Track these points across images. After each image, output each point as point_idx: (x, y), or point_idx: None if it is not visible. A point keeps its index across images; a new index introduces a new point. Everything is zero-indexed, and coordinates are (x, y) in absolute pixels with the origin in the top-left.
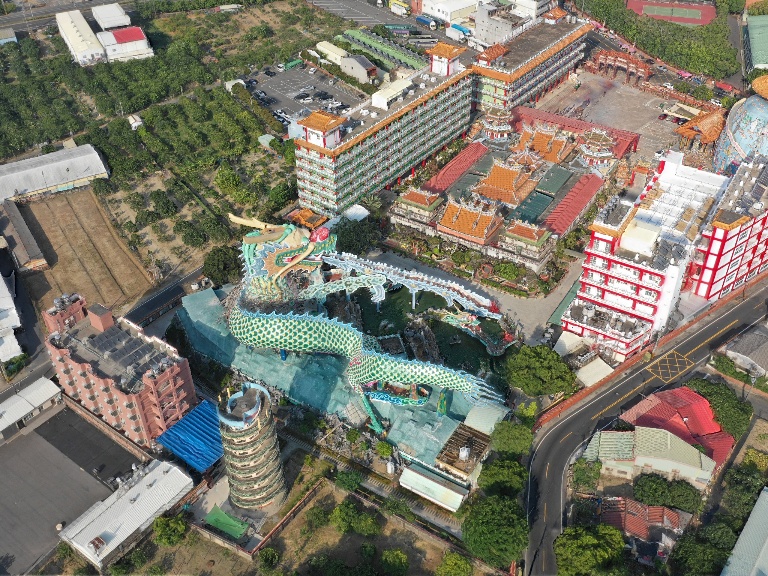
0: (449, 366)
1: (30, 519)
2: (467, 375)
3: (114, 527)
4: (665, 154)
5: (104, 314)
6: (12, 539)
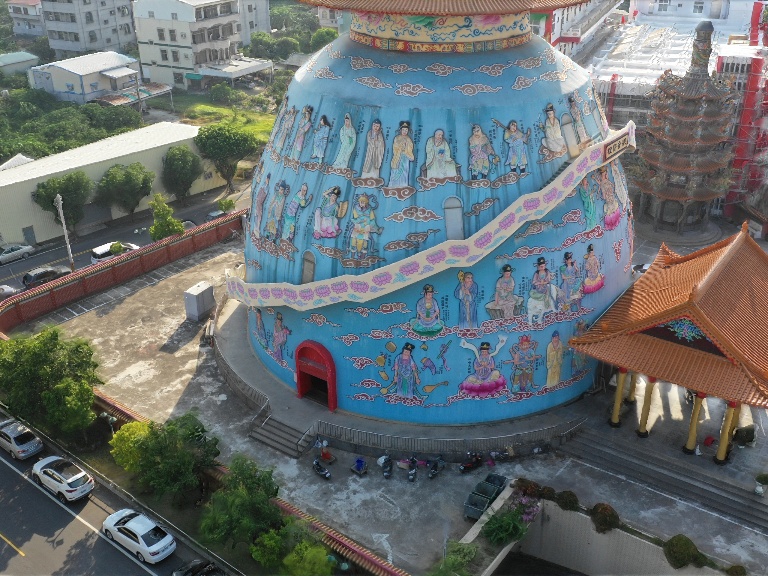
0: None
1: None
2: None
3: None
4: (766, 51)
5: None
6: None
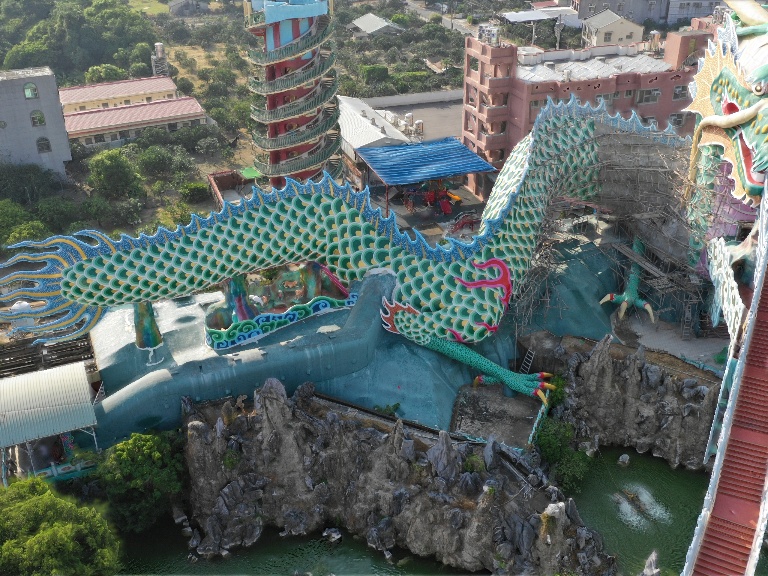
0: (356, 560)
1: (444, 121)
2: (73, 238)
3: (342, 107)
4: None
5: (675, 33)
6: (428, 115)
